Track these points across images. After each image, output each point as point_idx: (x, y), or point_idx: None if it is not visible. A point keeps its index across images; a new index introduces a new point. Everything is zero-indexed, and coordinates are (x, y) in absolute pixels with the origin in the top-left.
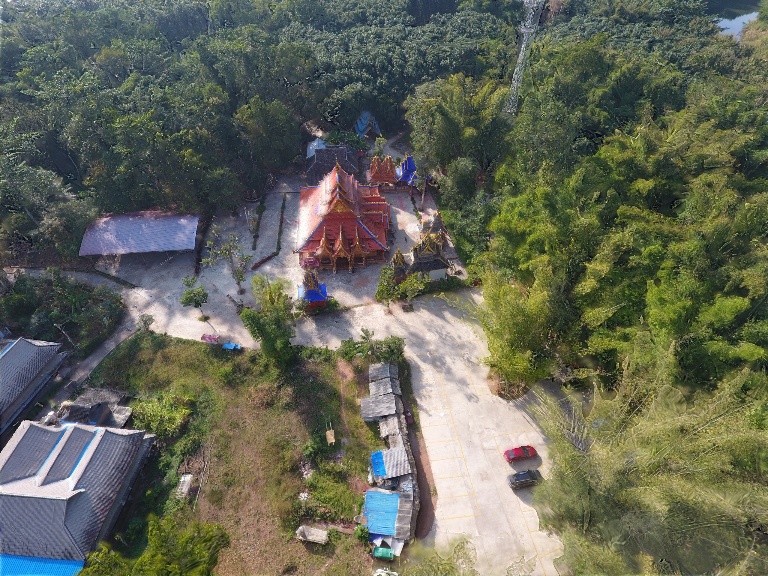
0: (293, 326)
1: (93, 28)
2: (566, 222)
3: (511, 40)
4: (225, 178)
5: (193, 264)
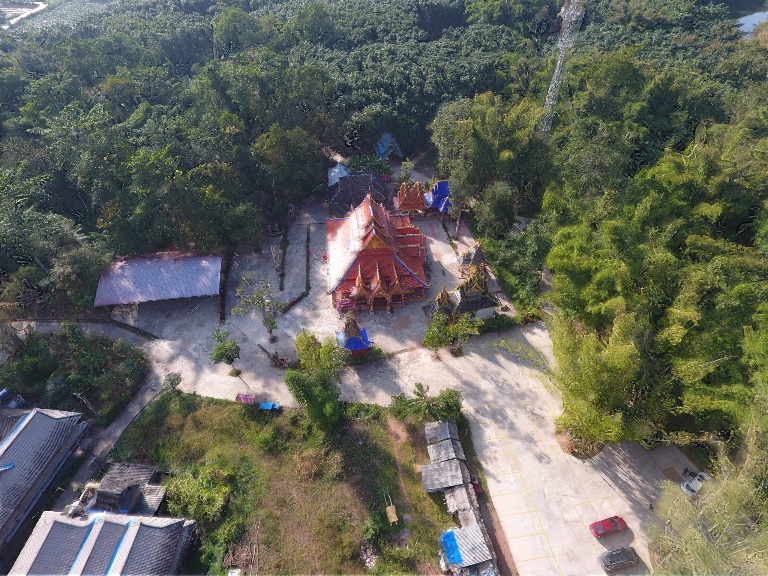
0: (339, 383)
1: (96, 55)
2: (638, 258)
3: (533, 53)
4: (248, 214)
5: (217, 309)
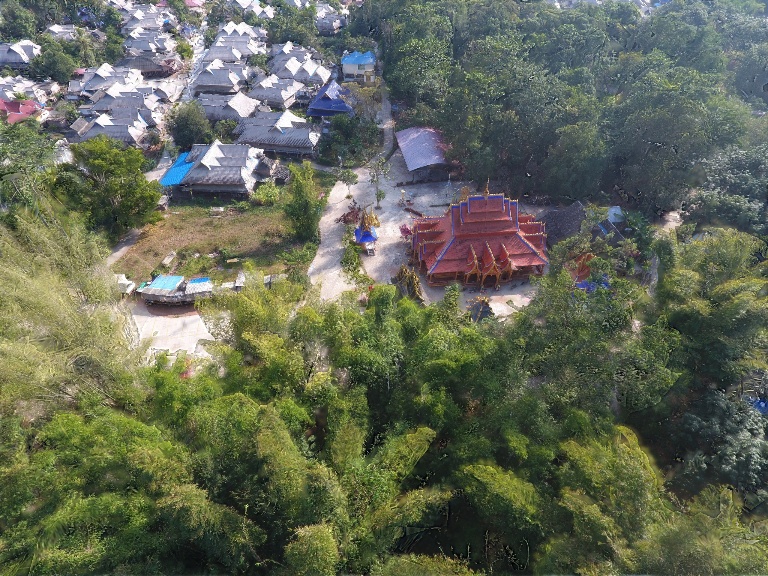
0: None
1: None
2: None
3: None
4: (479, 153)
5: None
